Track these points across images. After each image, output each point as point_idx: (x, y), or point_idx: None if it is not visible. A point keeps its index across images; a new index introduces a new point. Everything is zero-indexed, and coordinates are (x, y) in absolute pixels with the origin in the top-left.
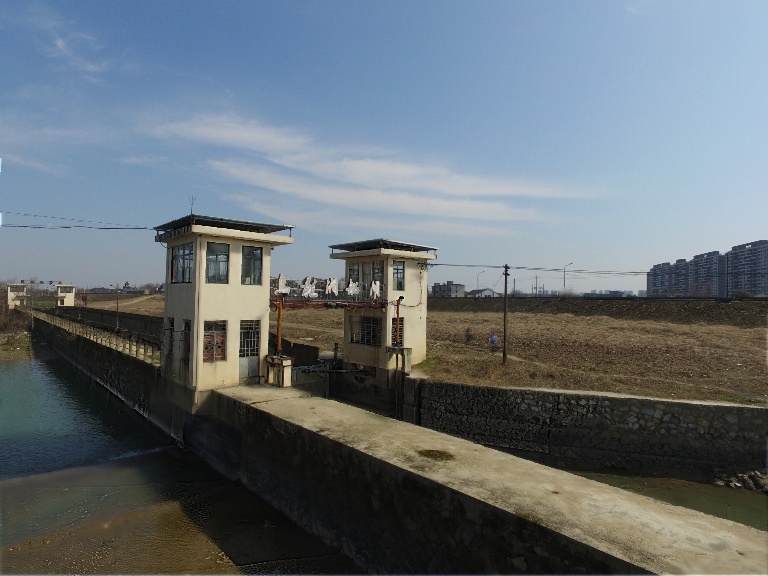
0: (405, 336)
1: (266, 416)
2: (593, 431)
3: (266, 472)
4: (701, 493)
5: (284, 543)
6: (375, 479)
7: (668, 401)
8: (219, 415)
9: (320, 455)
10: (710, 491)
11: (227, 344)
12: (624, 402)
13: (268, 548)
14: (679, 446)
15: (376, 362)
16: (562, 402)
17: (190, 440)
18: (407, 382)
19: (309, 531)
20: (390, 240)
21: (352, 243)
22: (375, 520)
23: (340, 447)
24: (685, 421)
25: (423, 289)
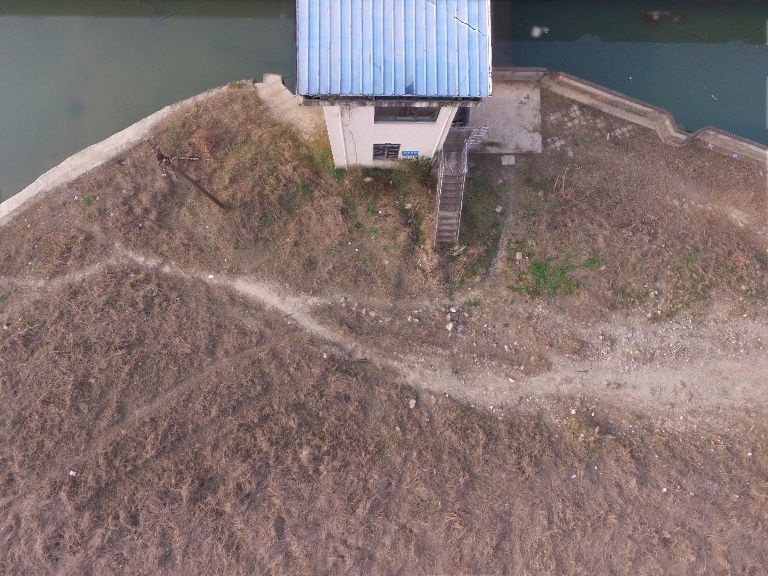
0: None
1: None
2: None
3: None
4: None
5: None
6: None
7: None
8: None
9: None
10: None
11: None
12: None
13: None
14: None
15: None
16: None
17: None
18: None
19: None
20: None
21: None
22: None
23: None
24: None
25: None
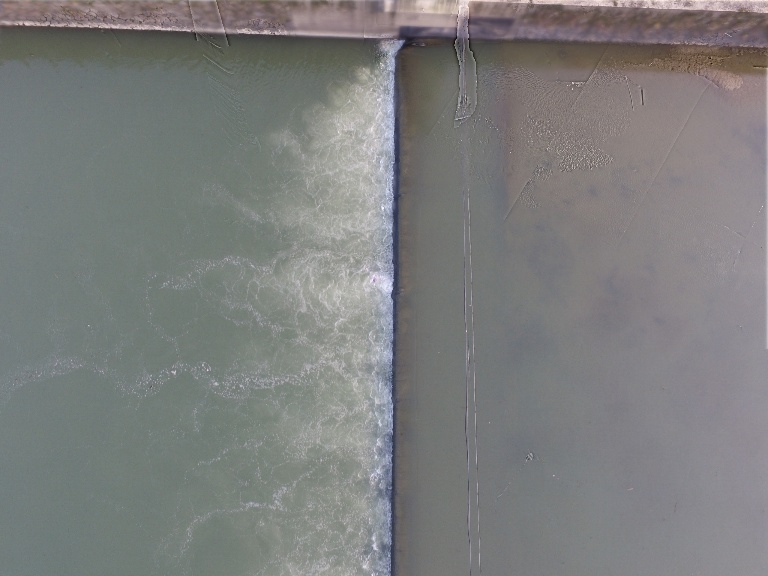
0: None
1: (558, 7)
2: None
3: None
4: None
5: (585, 58)
6: (661, 17)
7: None
8: (477, 14)
9: (614, 15)
10: None
11: None
12: None
13: (586, 66)
14: None
15: None
16: None
17: (415, 35)
18: None
19: (582, 43)
20: None
21: None
22: (648, 29)
23: None
24: None
25: None
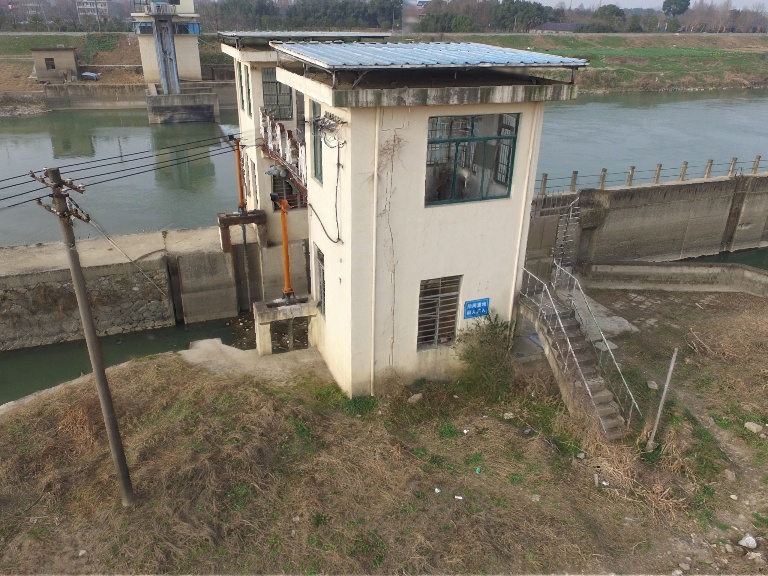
0: (327, 301)
1: None
2: None
3: None
4: None
5: None
6: None
7: None
8: None
9: None
10: None
11: None
12: None
13: None
14: None
15: None
16: None
17: None
18: None
19: None
20: None
21: None
22: None
23: None
24: None
25: (347, 202)
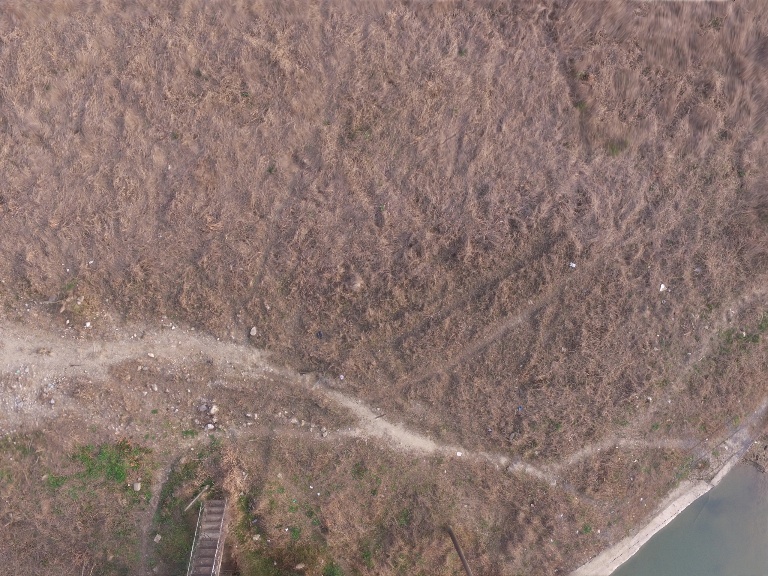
0: None
1: None
2: None
3: None
4: None
5: None
6: None
7: None
8: None
9: None
10: None
11: None
12: None
13: None
14: None
15: None
16: None
17: None
18: None
19: None
20: None
21: None
22: None
23: None
24: None
25: None
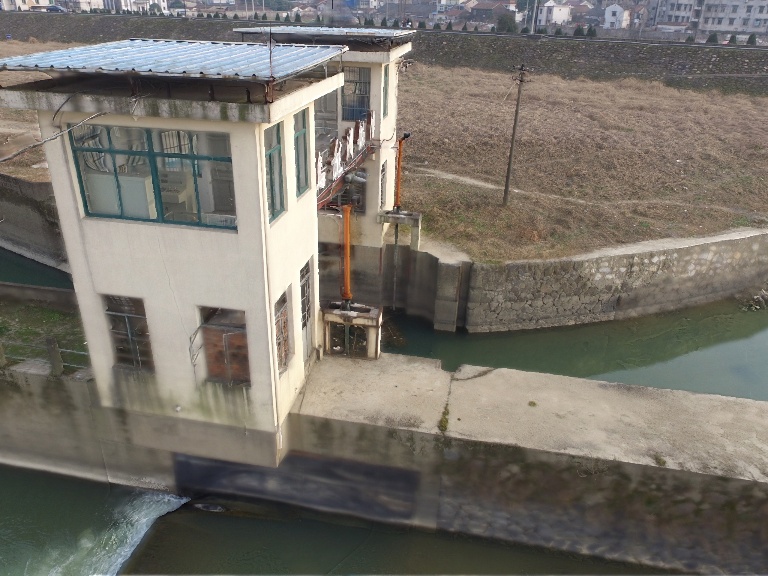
0: (386, 188)
1: (510, 451)
2: (659, 287)
3: (501, 516)
4: (747, 327)
5: None
6: None
7: (719, 241)
8: (327, 450)
9: (668, 492)
10: (748, 321)
11: (294, 325)
12: (689, 251)
13: None
14: (719, 283)
15: (356, 238)
16: (636, 263)
17: (209, 488)
18: (446, 271)
19: (620, 567)
20: (397, 33)
21: (309, 32)
22: None
23: (725, 482)
24: (726, 257)
25: None
